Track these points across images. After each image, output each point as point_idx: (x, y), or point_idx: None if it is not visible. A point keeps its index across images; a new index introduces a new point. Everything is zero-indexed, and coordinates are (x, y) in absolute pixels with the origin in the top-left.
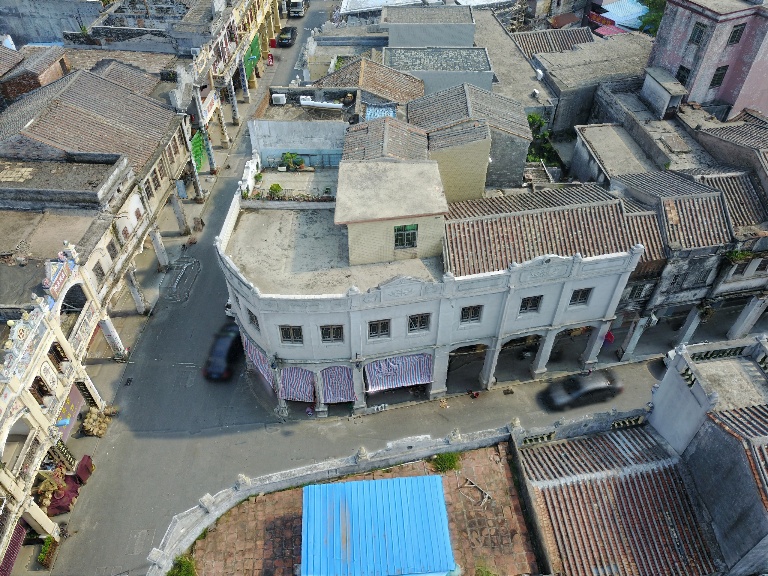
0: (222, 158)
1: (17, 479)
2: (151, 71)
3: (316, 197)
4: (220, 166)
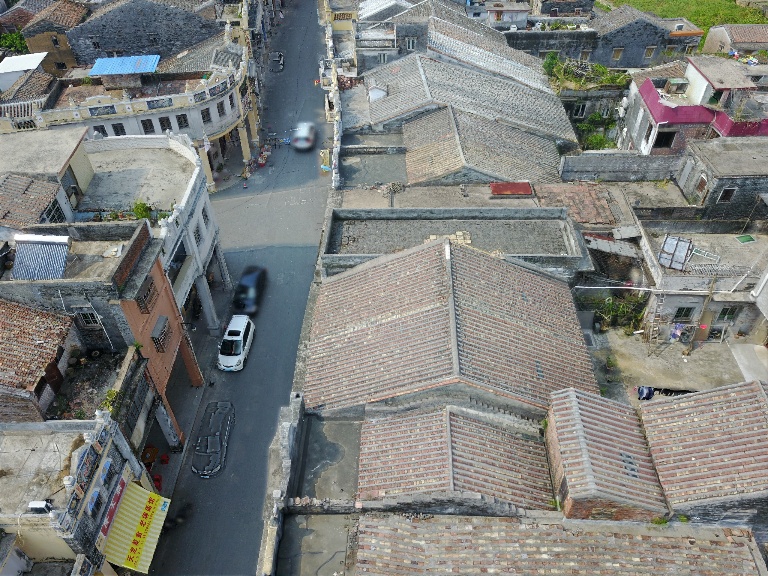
0: None
1: None
2: (375, 505)
3: None
4: None
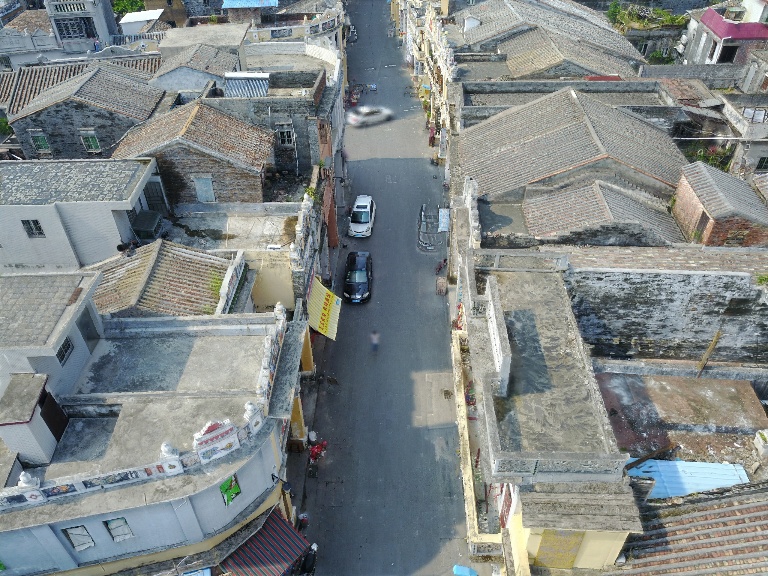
0: None
1: None
2: (551, 238)
3: None
4: None
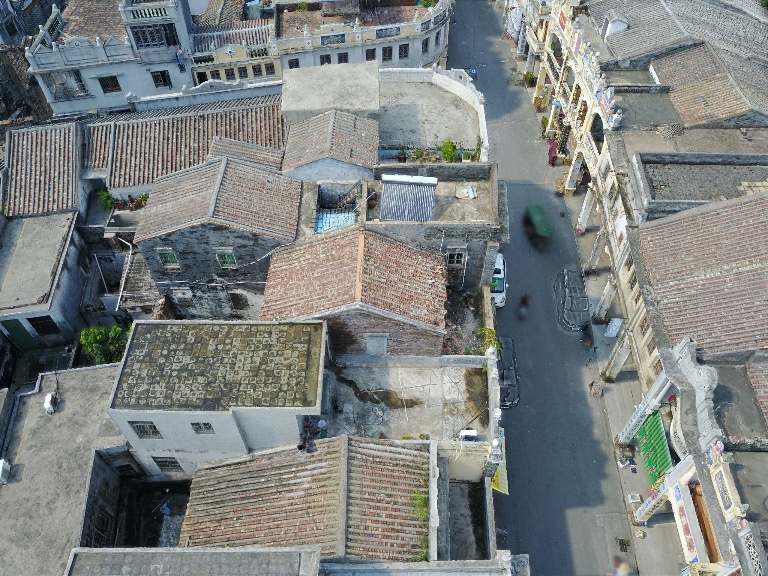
0: (647, 569)
1: (562, 84)
2: None
3: (406, 145)
4: (637, 542)
